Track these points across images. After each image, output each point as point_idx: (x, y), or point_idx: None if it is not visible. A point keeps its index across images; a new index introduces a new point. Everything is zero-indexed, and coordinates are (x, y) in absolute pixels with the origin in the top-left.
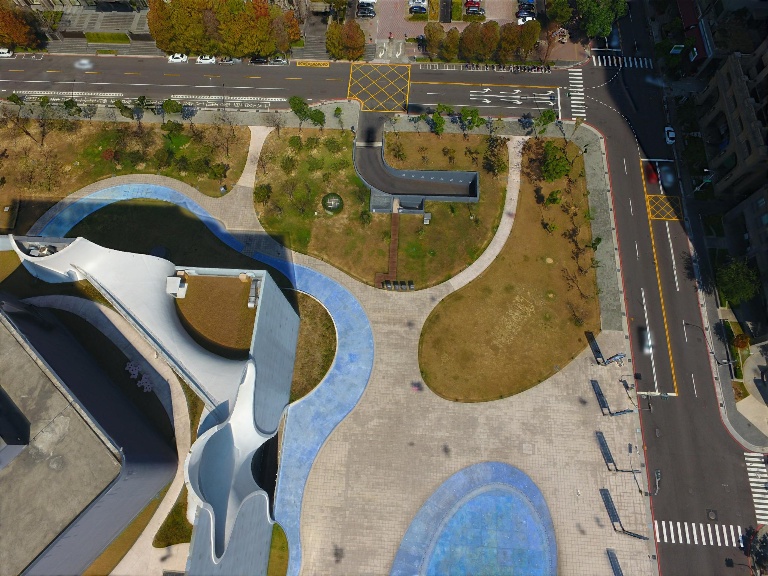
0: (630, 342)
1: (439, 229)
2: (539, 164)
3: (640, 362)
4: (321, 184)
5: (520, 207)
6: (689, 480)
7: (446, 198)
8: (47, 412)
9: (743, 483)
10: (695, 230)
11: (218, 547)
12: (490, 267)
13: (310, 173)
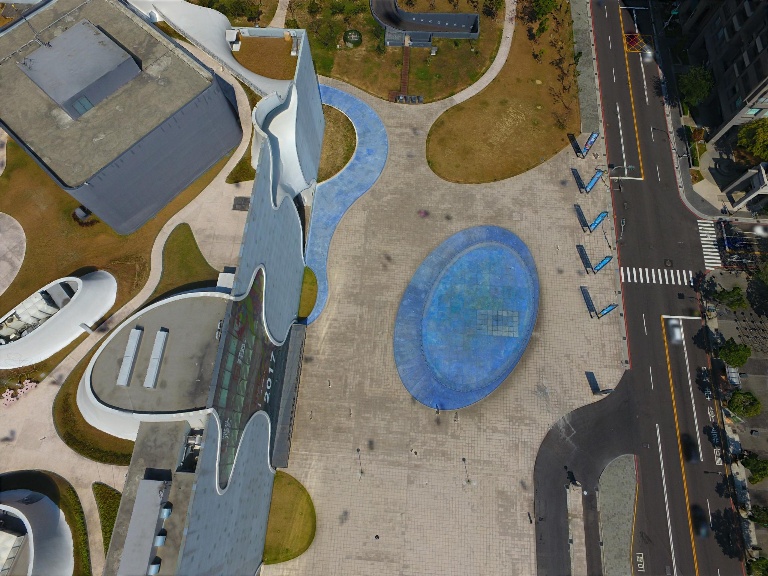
0: (605, 141)
1: (444, 58)
2: (532, 10)
3: (613, 156)
4: (342, 25)
5: (514, 43)
6: (651, 239)
7: (451, 34)
8: (154, 54)
9: (695, 241)
10: (664, 60)
11: None
12: (488, 87)
13: (333, 17)
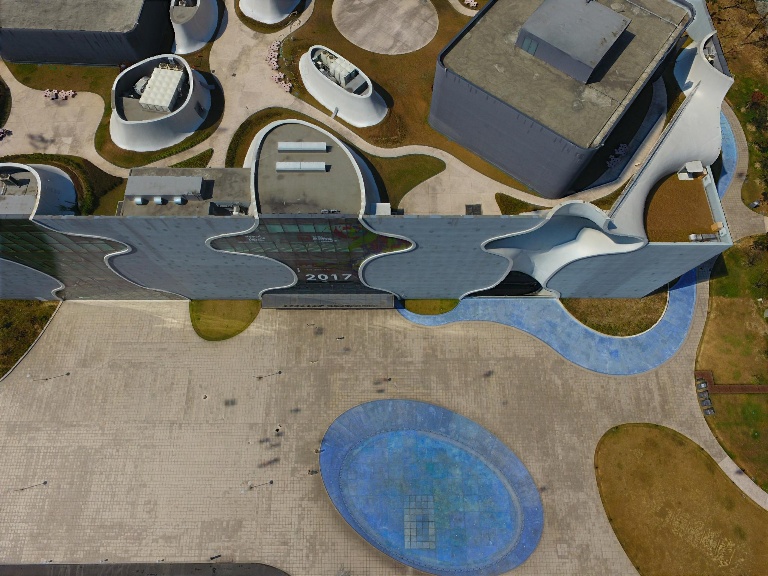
0: None
1: None
2: None
3: None
4: None
5: None
6: None
7: None
8: (611, 90)
9: None
10: None
11: (489, 244)
12: (760, 509)
13: None
